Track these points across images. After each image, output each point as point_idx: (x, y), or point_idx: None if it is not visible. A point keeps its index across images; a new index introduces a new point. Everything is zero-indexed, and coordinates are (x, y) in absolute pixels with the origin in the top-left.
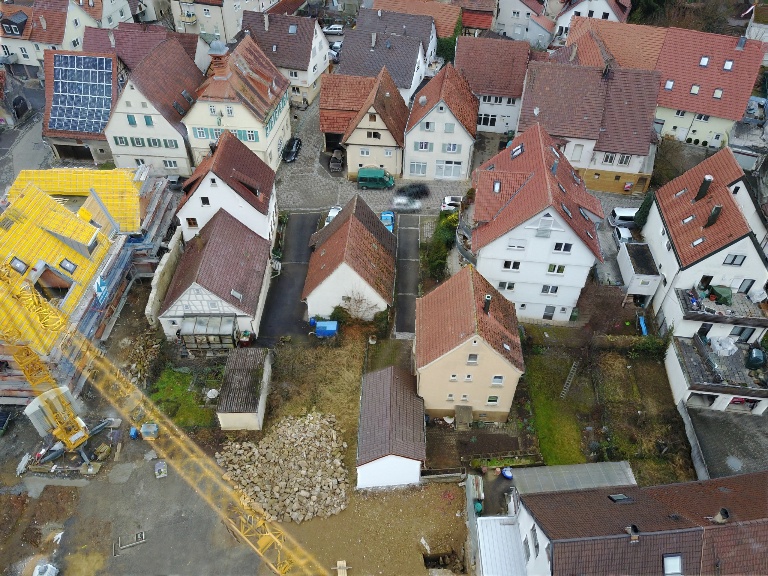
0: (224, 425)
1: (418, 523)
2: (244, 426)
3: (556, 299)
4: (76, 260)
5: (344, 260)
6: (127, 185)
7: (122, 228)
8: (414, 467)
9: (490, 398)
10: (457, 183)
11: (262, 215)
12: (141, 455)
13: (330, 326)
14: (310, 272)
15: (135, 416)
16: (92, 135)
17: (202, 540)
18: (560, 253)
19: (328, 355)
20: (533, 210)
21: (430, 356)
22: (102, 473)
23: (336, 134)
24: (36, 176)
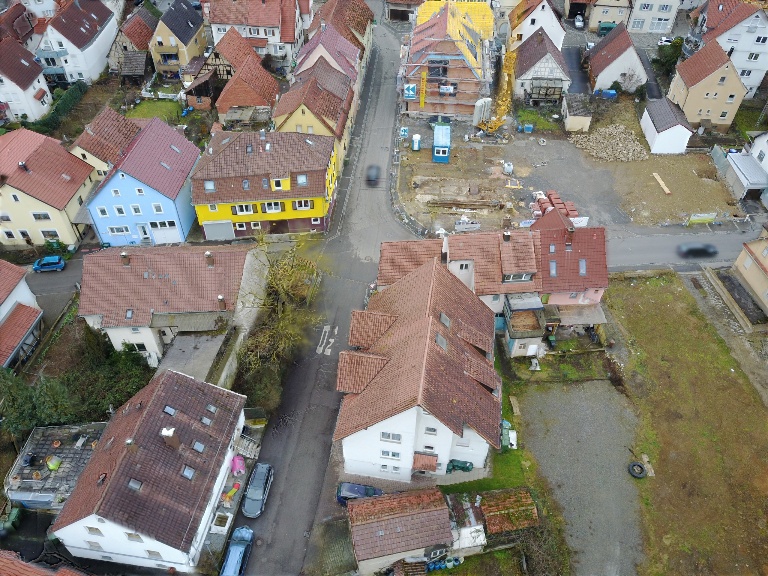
0: (569, 127)
1: (689, 165)
2: (581, 127)
3: (748, 80)
4: (474, 44)
5: (632, 45)
6: (487, 11)
7: (482, 37)
8: (686, 138)
9: (722, 114)
10: (663, 34)
11: (564, 32)
12: (527, 138)
13: (612, 91)
14: (595, 64)
15: (514, 125)
16: (419, 2)
17: (577, 165)
18: (759, 44)
19: (612, 106)
20: (749, 13)
21: (697, 81)
22: (510, 143)
23: (578, 5)
24: (434, 4)
